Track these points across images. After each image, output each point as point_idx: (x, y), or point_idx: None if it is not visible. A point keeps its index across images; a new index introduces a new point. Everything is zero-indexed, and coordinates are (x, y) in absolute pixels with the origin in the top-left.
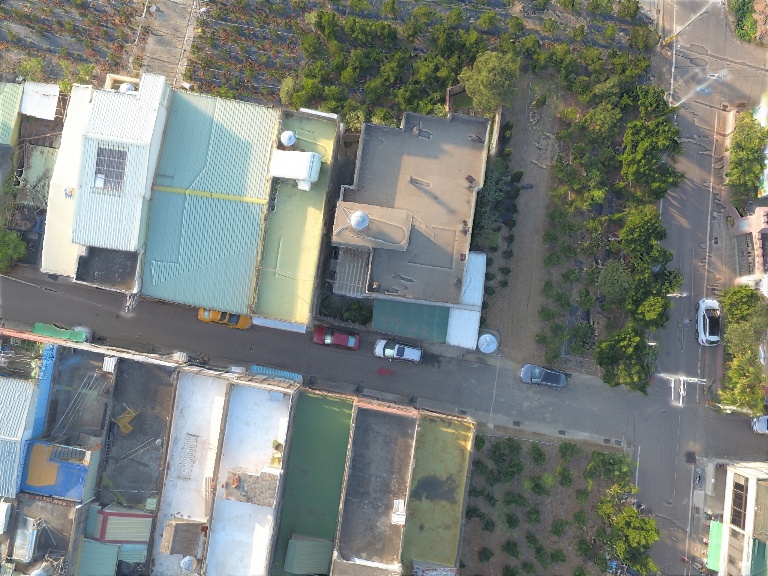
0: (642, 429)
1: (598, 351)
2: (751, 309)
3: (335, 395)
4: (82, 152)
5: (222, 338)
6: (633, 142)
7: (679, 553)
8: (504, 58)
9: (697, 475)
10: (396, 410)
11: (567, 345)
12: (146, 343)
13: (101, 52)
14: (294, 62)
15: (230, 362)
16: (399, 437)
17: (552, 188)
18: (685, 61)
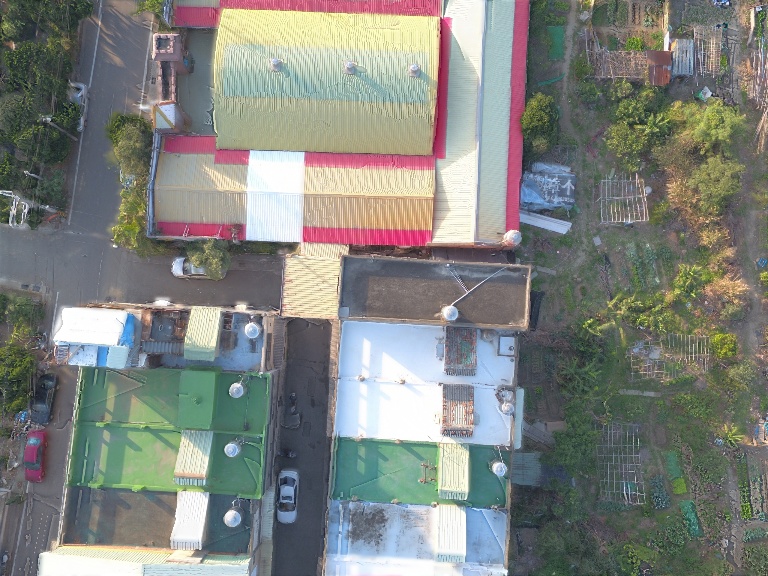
0: (61, 274)
1: None
2: (120, 133)
3: None
4: None
5: None
6: None
7: None
8: None
9: None
10: None
11: None
12: None
13: None
14: None
15: None
16: None
17: None
18: None
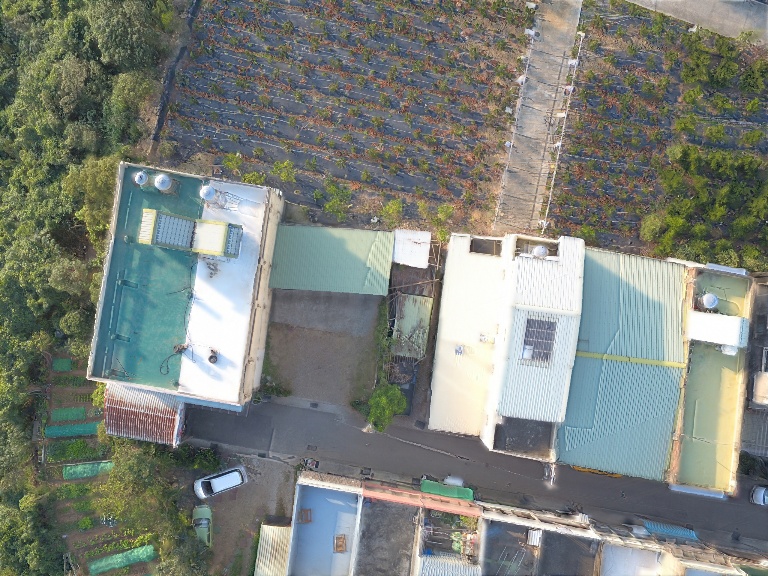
0: None
1: None
2: None
3: (763, 566)
4: (510, 323)
5: (593, 486)
6: None
7: None
8: None
9: None
10: None
11: None
12: (517, 492)
13: (455, 190)
14: (651, 196)
15: (603, 511)
16: None
17: None
18: None
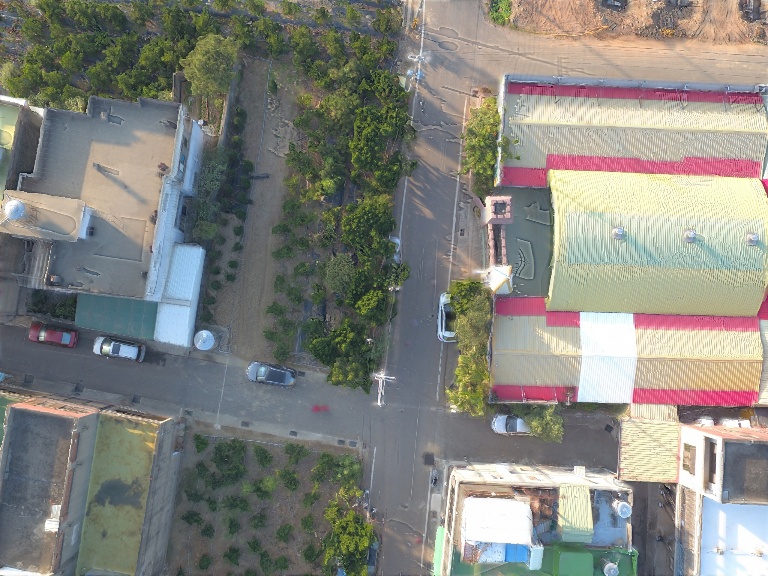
0: (378, 429)
1: (312, 348)
2: (469, 303)
3: (10, 394)
4: None
5: None
6: (359, 129)
7: (414, 559)
8: (224, 41)
9: (433, 477)
10: (59, 410)
11: (301, 342)
12: None
13: None
14: (19, 46)
15: None
16: (60, 439)
17: (286, 177)
18: (433, 45)
